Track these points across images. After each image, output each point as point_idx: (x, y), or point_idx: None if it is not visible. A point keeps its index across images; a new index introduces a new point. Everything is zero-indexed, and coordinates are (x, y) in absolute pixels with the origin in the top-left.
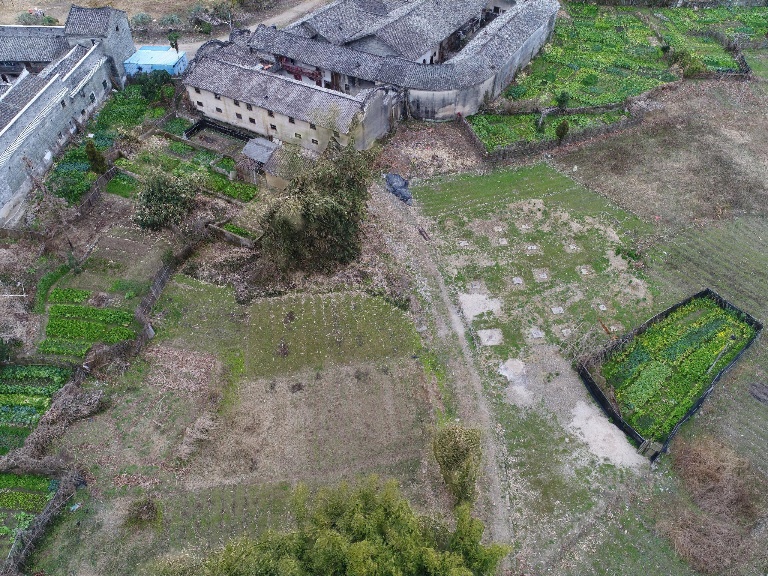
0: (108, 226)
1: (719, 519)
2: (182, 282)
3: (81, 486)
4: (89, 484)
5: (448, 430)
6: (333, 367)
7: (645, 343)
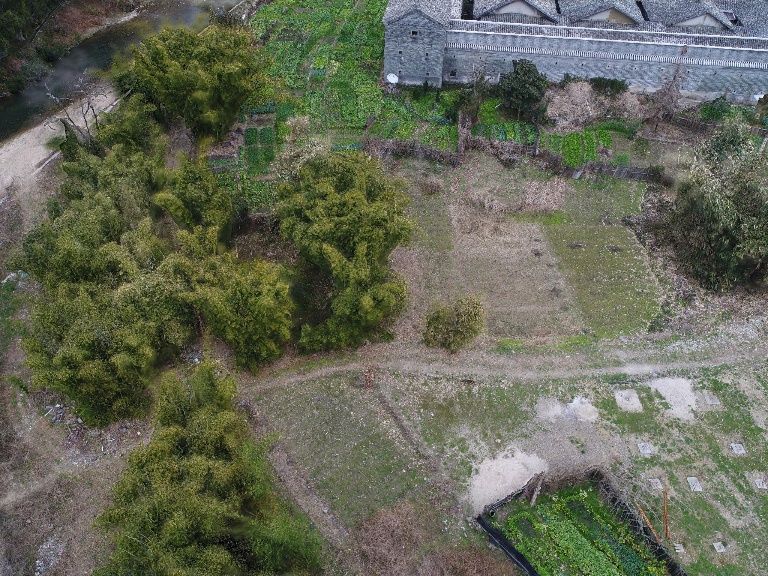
0: (690, 144)
1: (411, 572)
2: (638, 187)
3: (452, 166)
4: (453, 168)
5: (476, 299)
6: (563, 275)
7: (651, 567)
